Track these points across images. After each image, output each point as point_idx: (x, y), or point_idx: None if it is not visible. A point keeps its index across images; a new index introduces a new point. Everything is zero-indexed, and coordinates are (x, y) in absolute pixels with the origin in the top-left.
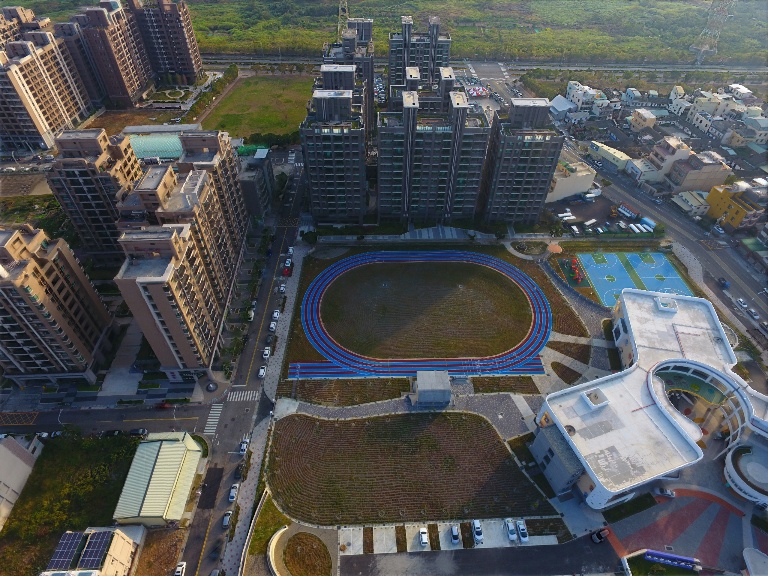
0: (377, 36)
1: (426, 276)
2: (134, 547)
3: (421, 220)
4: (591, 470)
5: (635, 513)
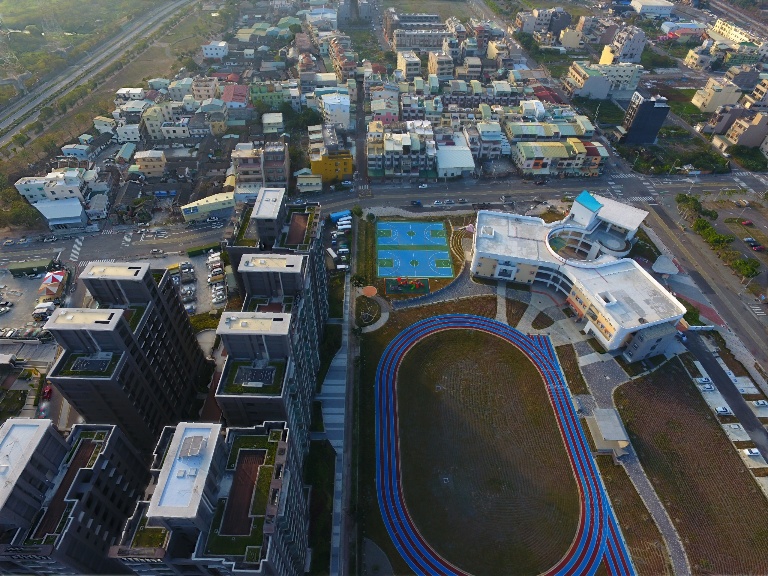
0: None
1: (424, 425)
2: None
3: None
4: (676, 316)
5: None
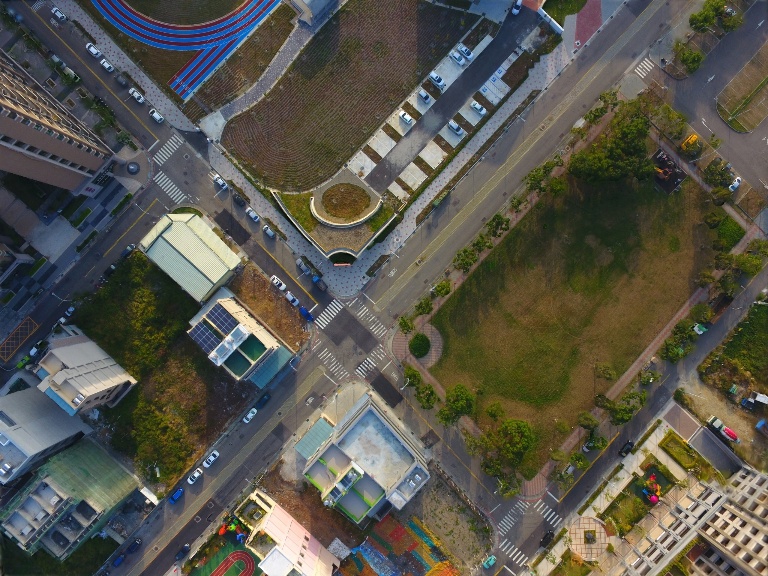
0: None
1: None
2: (233, 300)
3: None
4: None
5: None
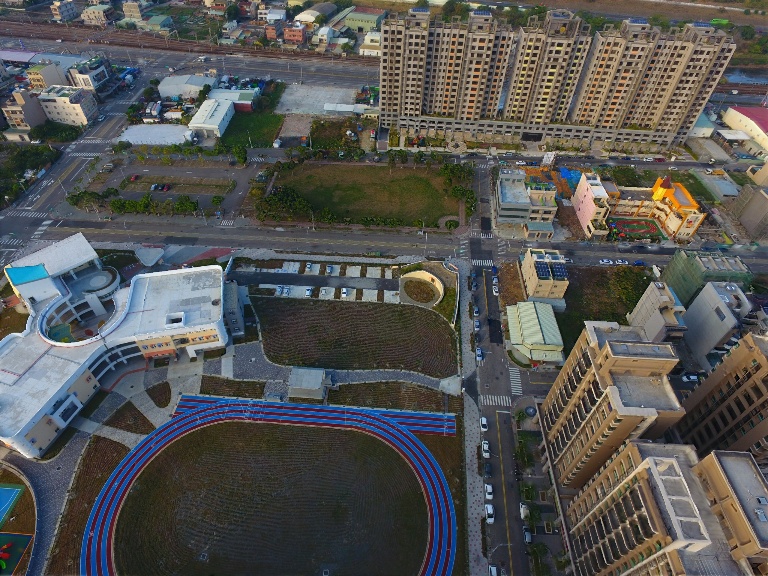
0: None
1: None
2: None
3: None
4: None
5: None
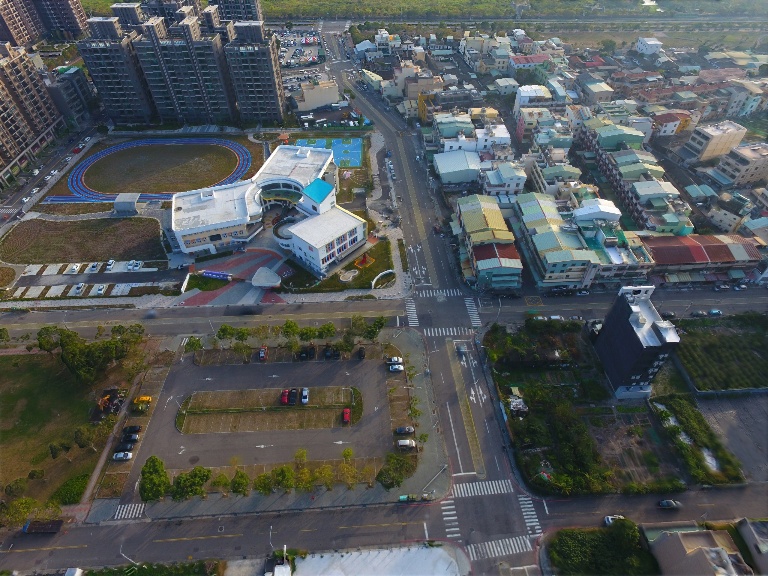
0: (263, 3)
1: (176, 152)
2: None
3: (194, 120)
4: None
5: (215, 258)
